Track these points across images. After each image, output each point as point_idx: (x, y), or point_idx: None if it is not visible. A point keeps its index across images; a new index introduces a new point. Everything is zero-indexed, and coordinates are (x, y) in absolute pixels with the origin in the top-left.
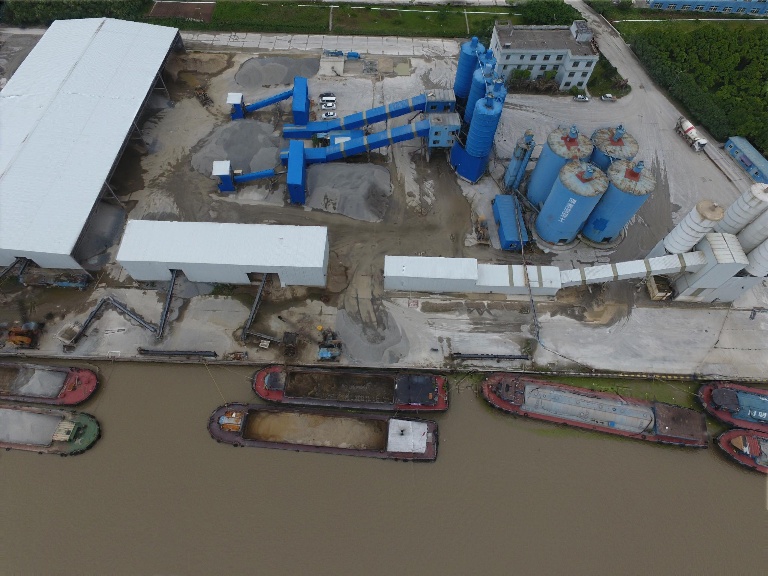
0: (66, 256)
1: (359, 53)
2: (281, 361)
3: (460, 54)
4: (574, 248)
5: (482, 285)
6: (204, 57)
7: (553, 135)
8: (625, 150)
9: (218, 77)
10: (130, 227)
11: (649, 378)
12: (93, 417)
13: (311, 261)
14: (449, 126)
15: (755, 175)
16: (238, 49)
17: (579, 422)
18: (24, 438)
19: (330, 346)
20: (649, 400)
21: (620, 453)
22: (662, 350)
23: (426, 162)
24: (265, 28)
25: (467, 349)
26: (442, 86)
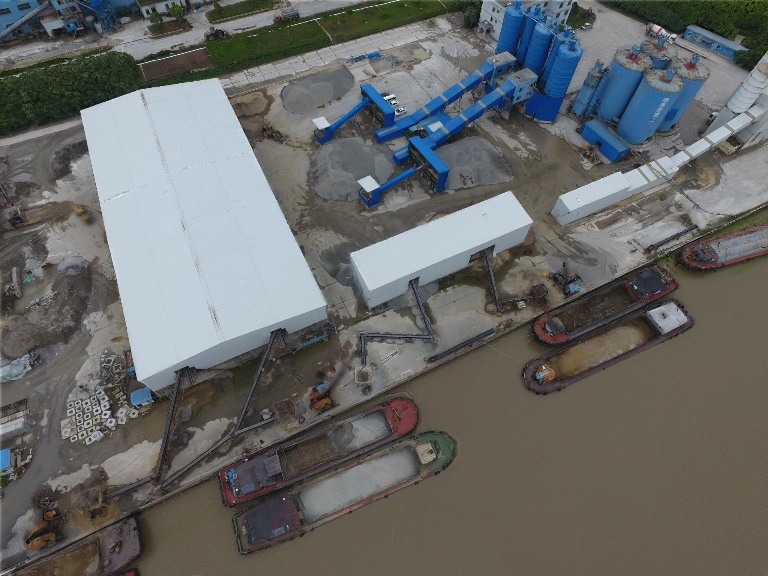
0: (322, 308)
1: None
2: (540, 312)
3: (507, 19)
4: (655, 142)
5: (631, 190)
6: (245, 99)
7: (619, 58)
8: (670, 52)
9: (270, 114)
10: (356, 259)
11: (766, 206)
12: (433, 432)
13: (521, 221)
14: (530, 80)
15: (717, 48)
16: (264, 83)
17: (755, 253)
18: (393, 480)
19: (571, 281)
20: None
21: None
22: (759, 185)
23: (506, 120)
24: (273, 56)
25: (651, 241)
26: (463, 57)
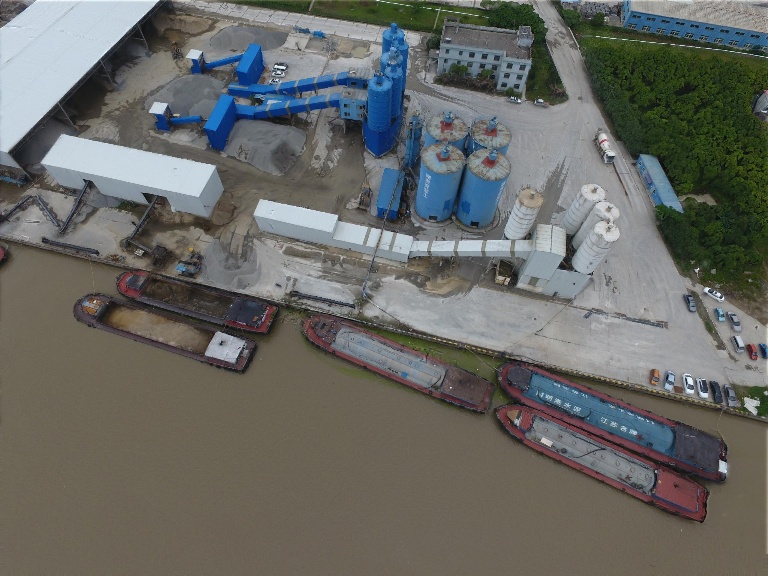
0: (5, 154)
1: (327, 33)
2: (149, 269)
3: None
4: (444, 227)
5: (338, 239)
6: (189, 19)
7: (435, 118)
8: (495, 141)
9: (196, 37)
10: (61, 140)
11: (461, 347)
12: None
13: (192, 190)
14: (356, 100)
15: (653, 193)
16: (223, 17)
17: (378, 368)
18: None
19: (189, 263)
20: (451, 364)
21: (403, 401)
22: (484, 326)
23: (343, 133)
24: (253, 2)
25: (308, 291)
26: None
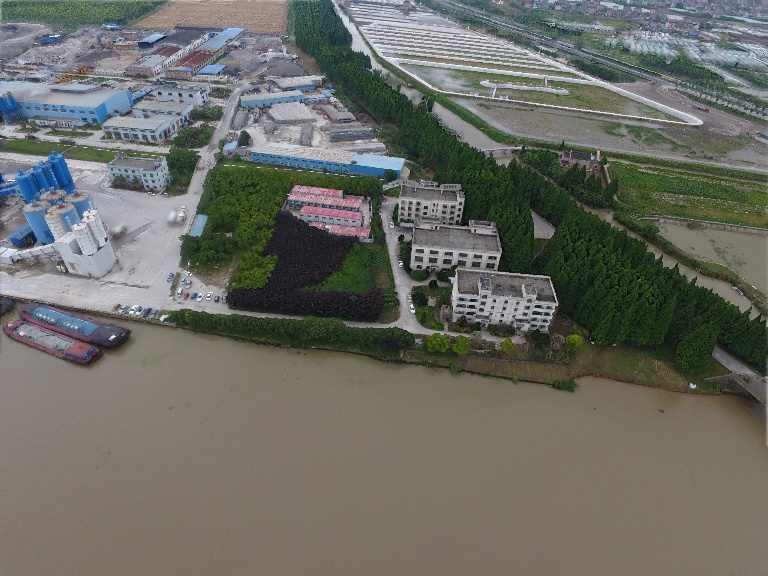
0: None
1: None
2: None
3: None
4: None
5: None
6: None
7: None
8: (75, 199)
9: None
10: None
11: None
12: None
13: None
14: None
15: None
16: None
17: None
18: None
19: None
20: None
21: None
22: (34, 290)
23: None
24: (25, 152)
25: None
26: (84, 182)
